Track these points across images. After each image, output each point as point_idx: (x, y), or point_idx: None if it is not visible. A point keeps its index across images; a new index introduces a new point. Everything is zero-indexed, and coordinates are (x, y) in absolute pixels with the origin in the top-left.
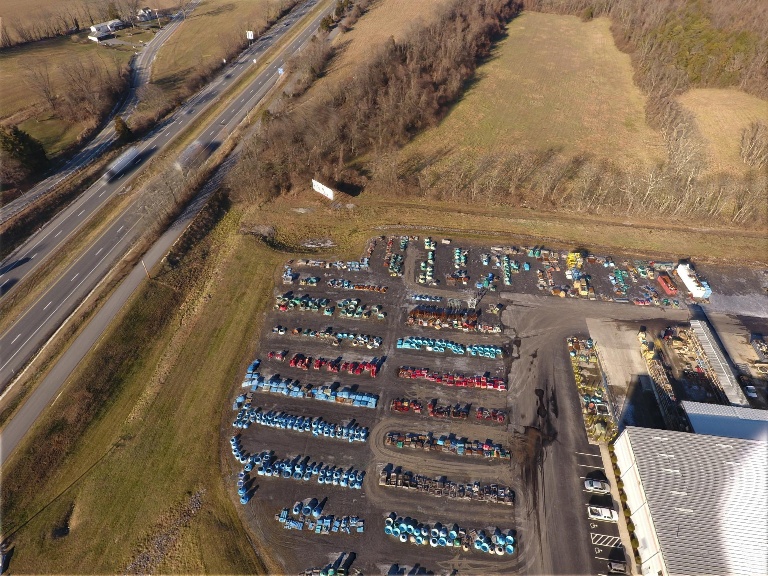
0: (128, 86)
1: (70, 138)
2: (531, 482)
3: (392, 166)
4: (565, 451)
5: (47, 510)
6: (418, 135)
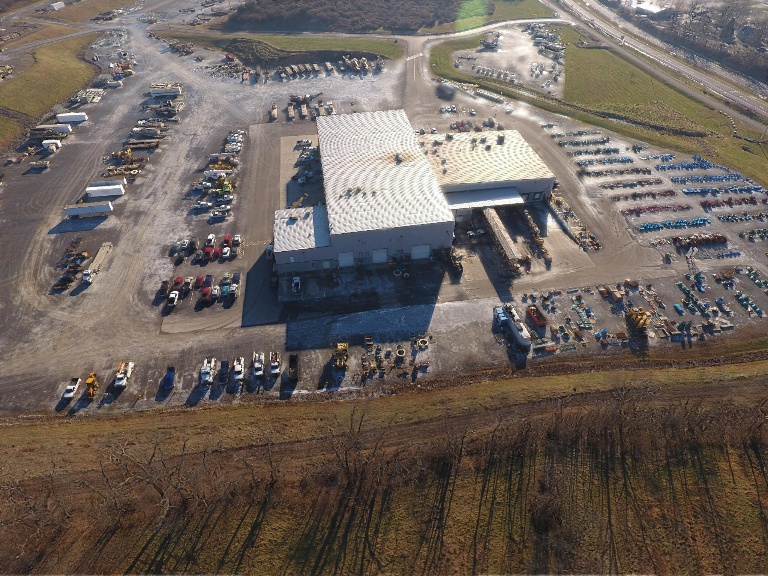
0: None
1: None
2: (582, 180)
3: None
4: (572, 192)
5: (761, 151)
6: None
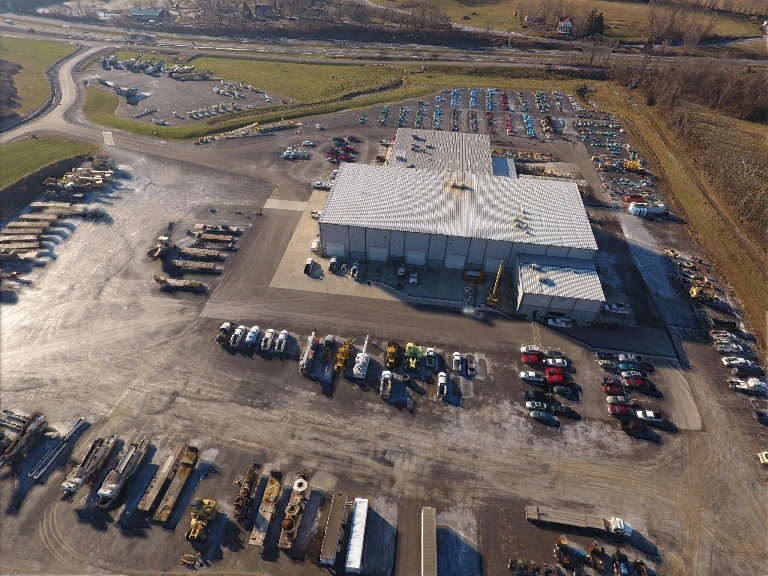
0: (709, 41)
1: (628, 39)
2: None
3: (671, 93)
4: None
5: None
6: (766, 124)
